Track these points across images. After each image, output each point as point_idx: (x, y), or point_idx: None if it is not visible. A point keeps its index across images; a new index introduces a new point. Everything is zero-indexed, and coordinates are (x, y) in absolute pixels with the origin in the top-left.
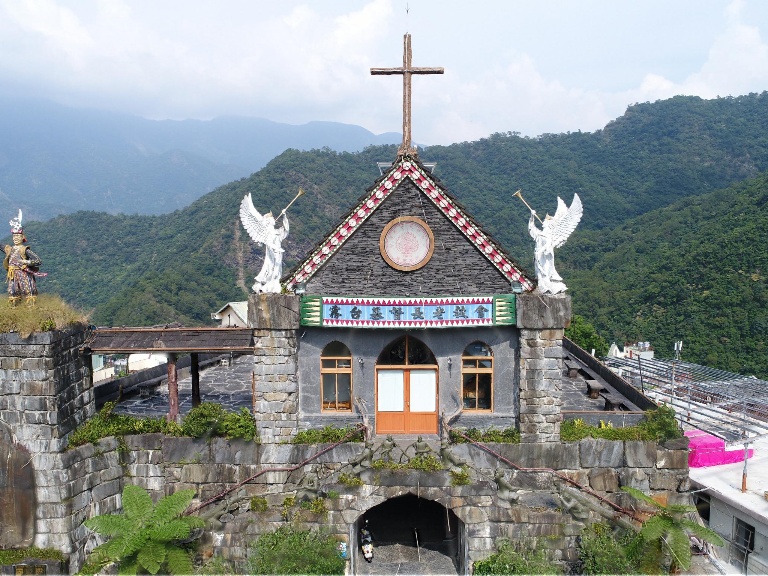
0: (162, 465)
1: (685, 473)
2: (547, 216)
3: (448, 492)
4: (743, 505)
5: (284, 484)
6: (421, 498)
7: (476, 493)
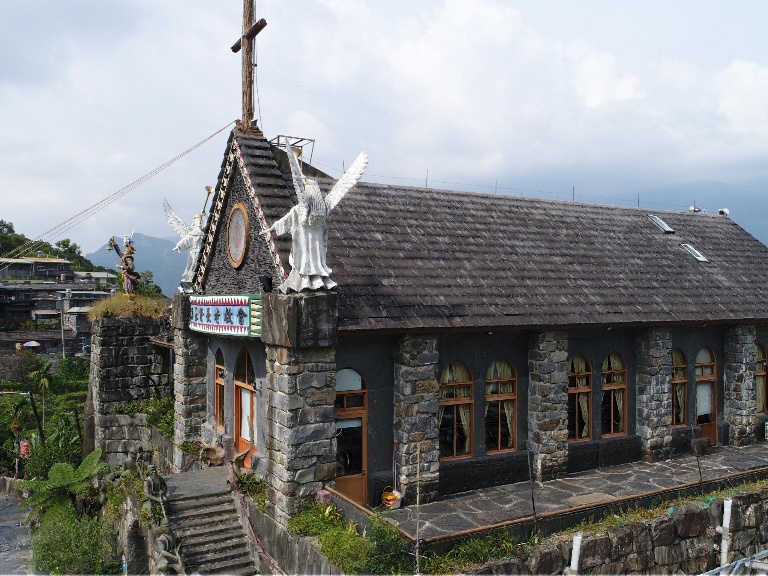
0: None
1: None
2: None
3: None
4: None
5: None
6: None
7: None
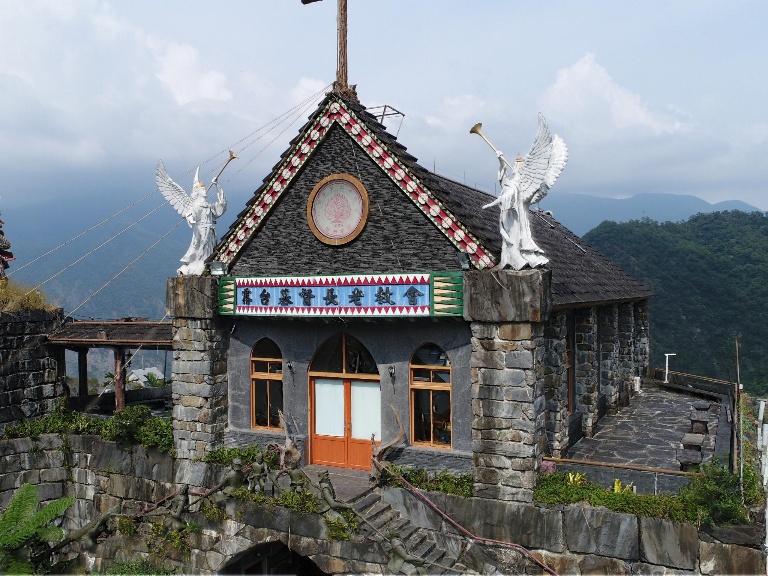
0: None
1: None
2: None
3: (324, 548)
4: None
5: None
6: (292, 550)
7: (359, 556)
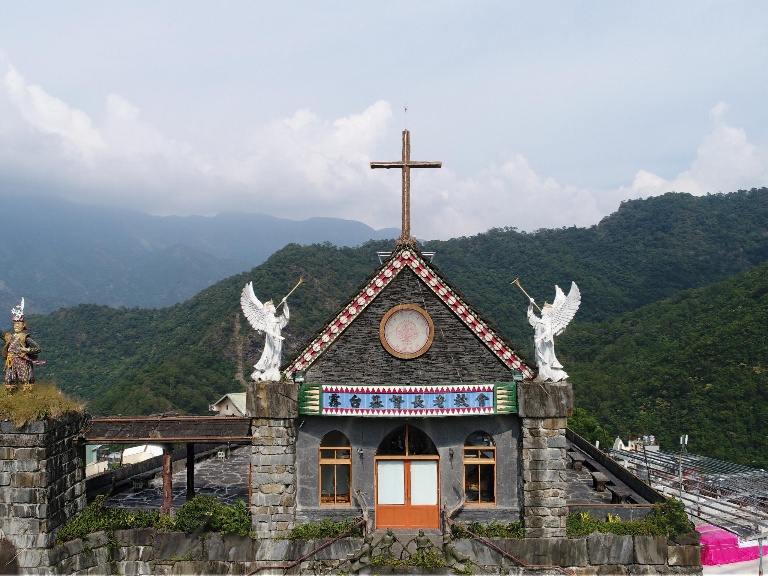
0: (153, 562)
1: (698, 570)
2: (546, 304)
3: None
4: None
5: None
6: None
7: None
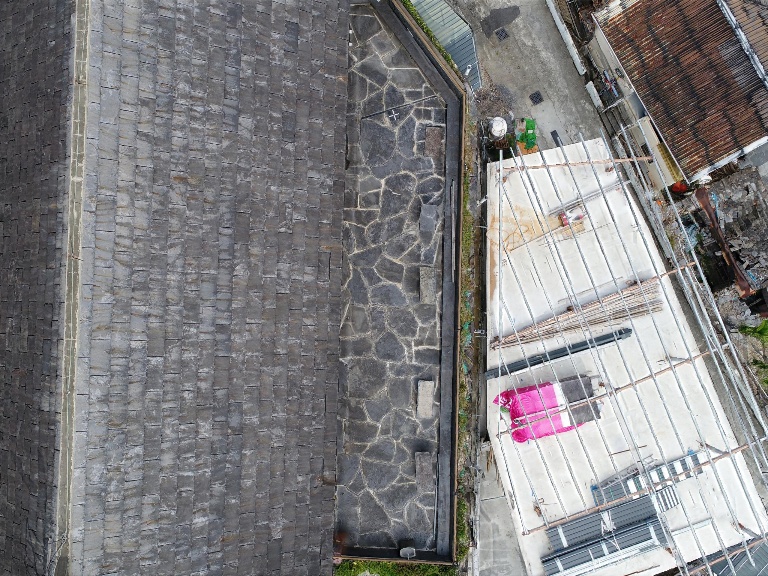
0: None
1: None
2: None
3: None
4: (519, 542)
5: None
6: None
7: None
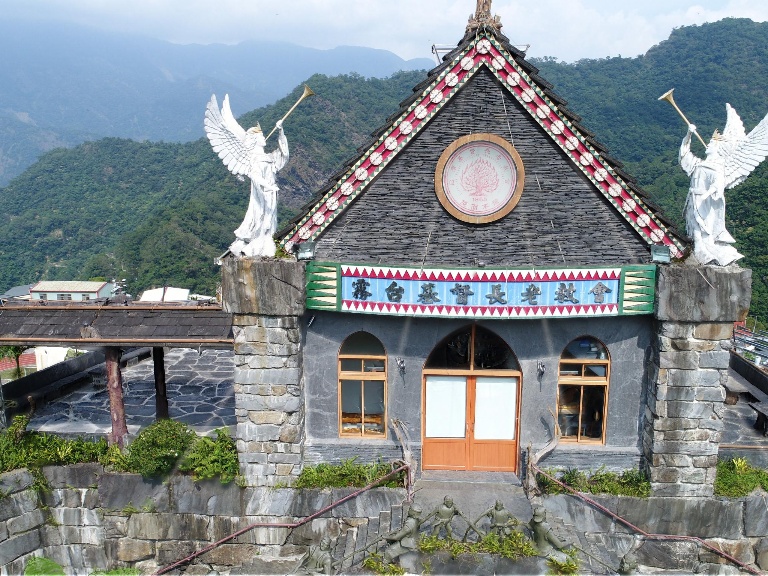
0: None
1: None
2: (716, 134)
3: None
4: None
5: (282, 546)
6: None
7: None
